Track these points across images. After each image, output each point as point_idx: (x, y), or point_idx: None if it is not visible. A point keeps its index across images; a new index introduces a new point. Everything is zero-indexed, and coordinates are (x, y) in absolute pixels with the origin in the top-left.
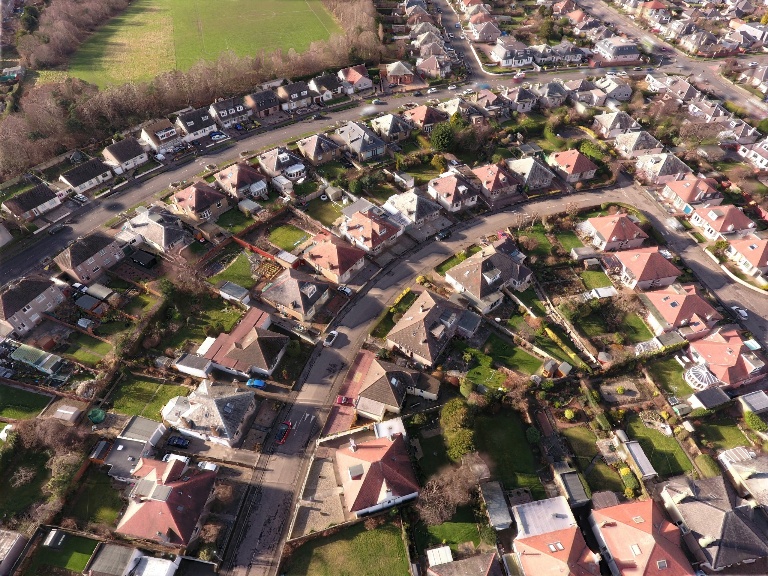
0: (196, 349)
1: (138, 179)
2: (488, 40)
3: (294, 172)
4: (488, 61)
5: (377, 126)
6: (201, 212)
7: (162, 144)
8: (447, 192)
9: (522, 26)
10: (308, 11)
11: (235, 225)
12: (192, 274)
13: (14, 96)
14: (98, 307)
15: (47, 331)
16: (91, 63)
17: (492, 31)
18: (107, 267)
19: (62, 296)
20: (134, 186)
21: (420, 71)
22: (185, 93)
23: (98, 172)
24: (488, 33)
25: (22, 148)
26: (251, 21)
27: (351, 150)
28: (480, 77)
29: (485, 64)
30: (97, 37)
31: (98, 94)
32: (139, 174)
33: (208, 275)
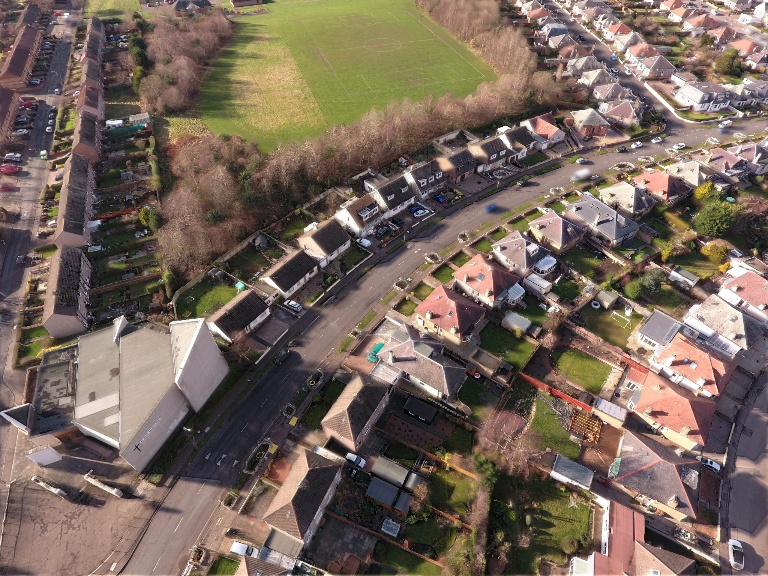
0: (557, 573)
1: (350, 275)
2: (661, 77)
3: (547, 268)
4: (675, 104)
5: (612, 199)
6: (468, 335)
7: (365, 226)
8: (763, 302)
9: (685, 58)
10: (436, 40)
11: (507, 350)
12: (526, 453)
13: (155, 154)
14: (401, 500)
15: (338, 539)
16: (223, 107)
17: (665, 67)
18: (374, 422)
19: (339, 477)
20: (349, 286)
21: (612, 119)
22: (365, 154)
23: (306, 269)
24: (661, 69)
25: (206, 236)
26: (379, 53)
27: (595, 233)
28: (679, 126)
29: (677, 109)
30: (215, 73)
31: (270, 158)
32: (350, 269)
33: (512, 436)
